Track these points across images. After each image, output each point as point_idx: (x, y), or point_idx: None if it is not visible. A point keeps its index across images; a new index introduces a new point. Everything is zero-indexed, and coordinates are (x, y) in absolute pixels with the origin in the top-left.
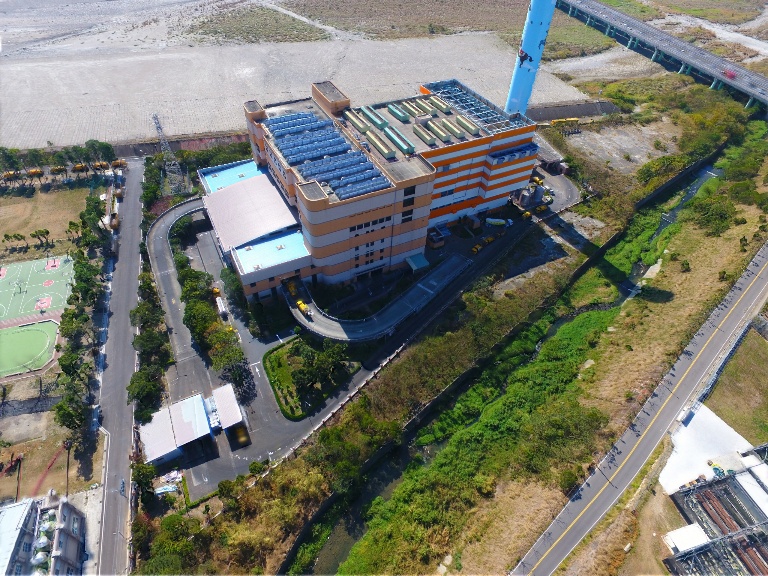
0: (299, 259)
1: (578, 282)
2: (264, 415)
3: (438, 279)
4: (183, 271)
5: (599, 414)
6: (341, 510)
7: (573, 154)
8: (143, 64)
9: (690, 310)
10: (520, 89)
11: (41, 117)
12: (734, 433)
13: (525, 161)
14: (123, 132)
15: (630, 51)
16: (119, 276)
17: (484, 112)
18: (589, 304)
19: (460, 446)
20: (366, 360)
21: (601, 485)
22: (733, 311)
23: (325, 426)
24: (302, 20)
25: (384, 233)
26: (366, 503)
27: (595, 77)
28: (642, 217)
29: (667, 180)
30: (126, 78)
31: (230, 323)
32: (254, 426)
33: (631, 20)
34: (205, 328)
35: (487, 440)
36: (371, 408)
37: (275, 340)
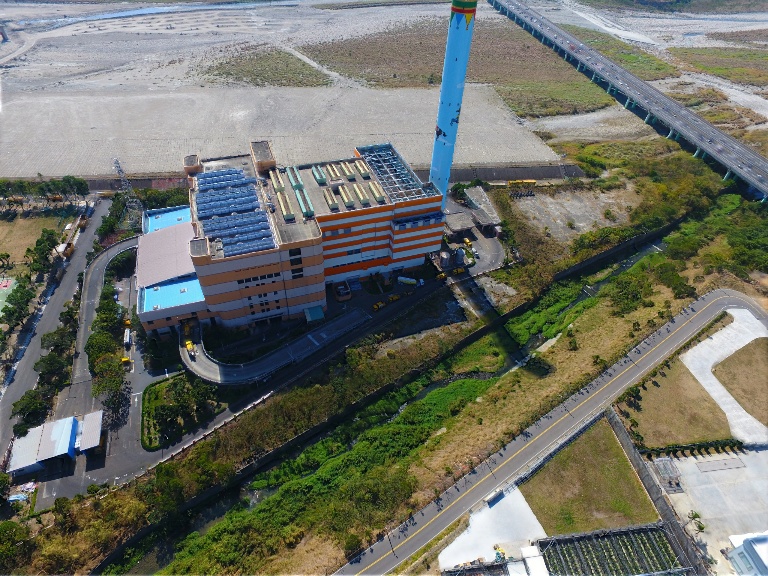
0: (194, 303)
1: (467, 348)
2: (125, 442)
3: (329, 332)
4: (103, 302)
5: (414, 483)
6: (158, 539)
7: (516, 217)
8: (152, 102)
9: (550, 391)
10: (439, 159)
11: (48, 148)
12: (535, 521)
13: (432, 228)
14: (110, 166)
15: (626, 111)
16: (54, 300)
17: (402, 178)
18: (469, 371)
19: (286, 495)
20: (234, 402)
21: (384, 552)
22: (593, 397)
23: (172, 459)
24: (312, 65)
25: (276, 286)
26: (182, 536)
27: (577, 137)
28: (560, 288)
29: (600, 252)
30: (133, 115)
31: (130, 354)
32: (113, 451)
33: (634, 80)
34: (98, 357)
35: (314, 493)
36: (218, 448)
37: (162, 374)
